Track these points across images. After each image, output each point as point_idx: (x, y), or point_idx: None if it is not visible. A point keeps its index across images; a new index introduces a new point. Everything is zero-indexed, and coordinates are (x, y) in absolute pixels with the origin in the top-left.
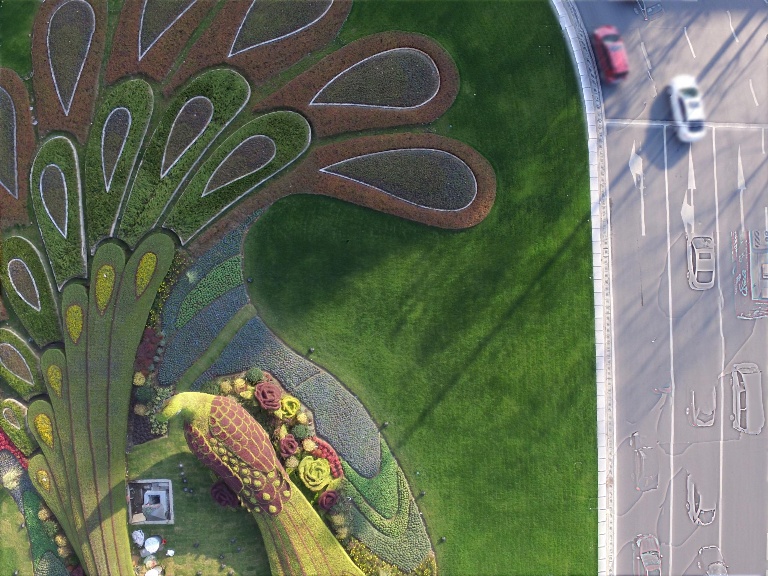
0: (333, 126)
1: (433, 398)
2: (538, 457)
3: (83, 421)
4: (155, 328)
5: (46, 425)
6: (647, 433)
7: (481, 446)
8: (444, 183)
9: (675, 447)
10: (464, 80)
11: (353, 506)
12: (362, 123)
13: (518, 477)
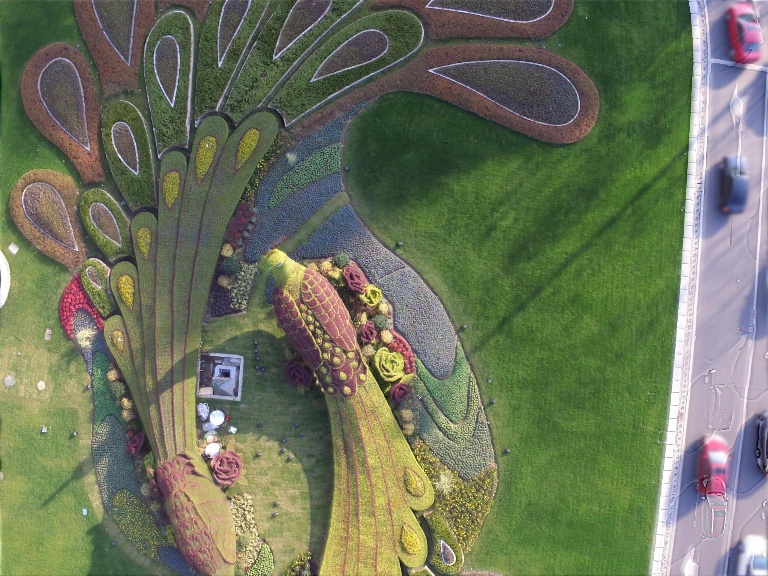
0: (446, 30)
1: (514, 307)
2: (612, 381)
3: (167, 284)
4: (249, 203)
5: (129, 285)
6: (725, 371)
7: (556, 362)
8: (549, 97)
9: (750, 391)
10: (577, 3)
11: (422, 406)
12: (474, 31)
13: (590, 399)
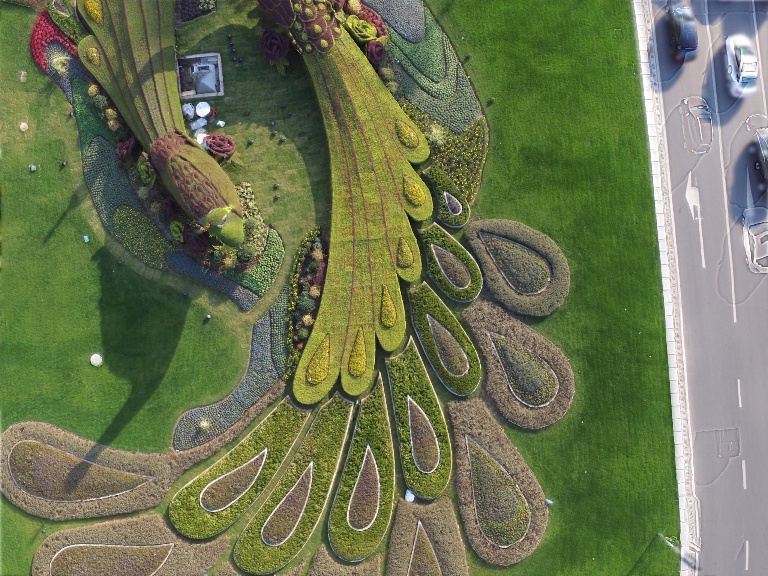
0: None
1: None
2: (578, 22)
3: None
4: None
5: (96, 3)
6: None
7: (522, 11)
8: None
9: (710, 17)
10: None
11: (401, 69)
12: None
13: (561, 40)
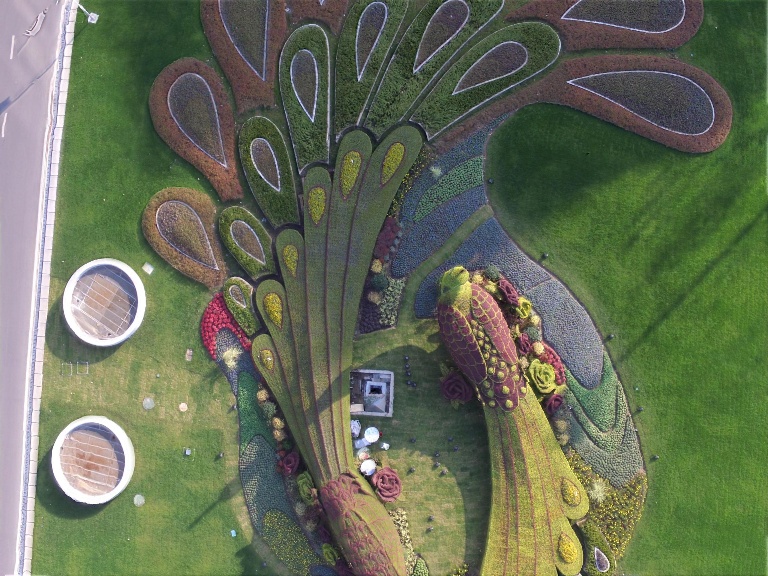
0: (583, 41)
1: (659, 316)
2: (753, 385)
3: (319, 302)
4: (395, 218)
5: (277, 304)
6: None
7: (700, 368)
8: (686, 107)
9: None
10: (707, 13)
11: (572, 416)
12: (610, 41)
13: (733, 403)
